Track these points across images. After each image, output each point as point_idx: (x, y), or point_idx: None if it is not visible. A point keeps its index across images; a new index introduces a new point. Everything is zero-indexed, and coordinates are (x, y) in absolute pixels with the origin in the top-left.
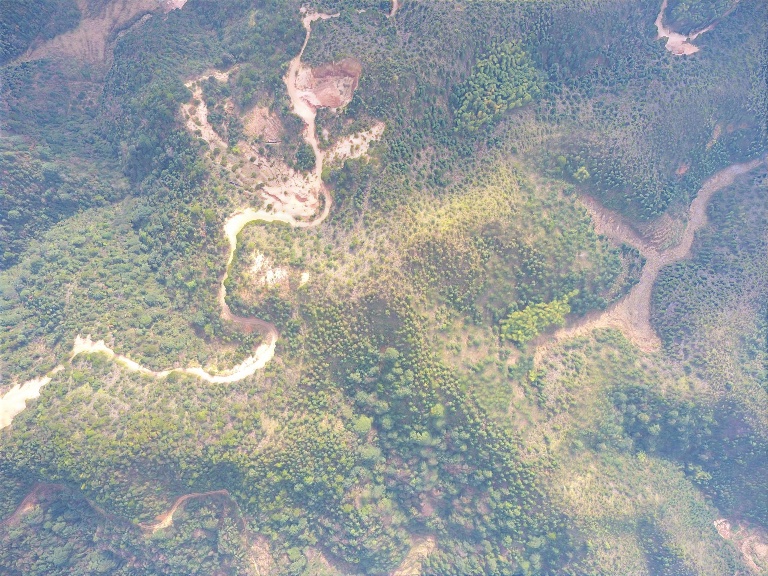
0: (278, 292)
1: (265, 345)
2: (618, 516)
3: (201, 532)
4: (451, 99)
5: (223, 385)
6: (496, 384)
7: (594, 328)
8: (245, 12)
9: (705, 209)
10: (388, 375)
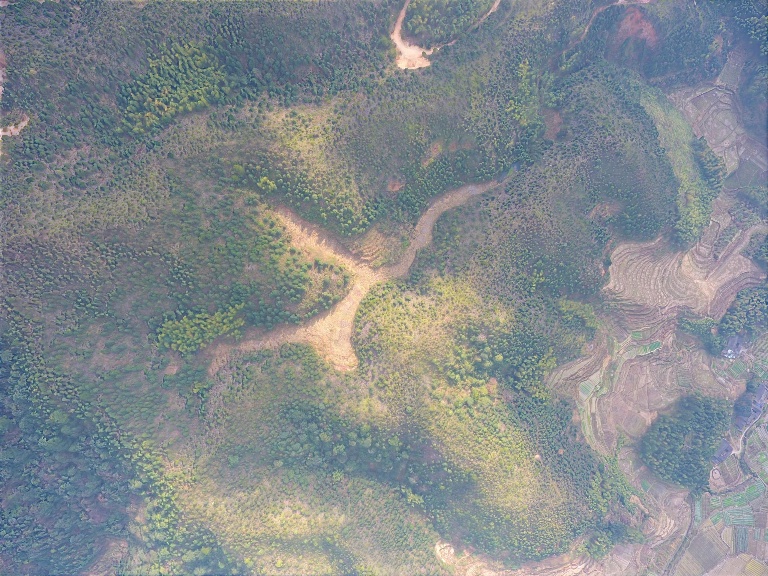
0: None
1: None
2: (287, 535)
3: None
4: (118, 98)
5: None
6: (142, 394)
7: (285, 343)
8: None
9: (432, 229)
10: (9, 377)
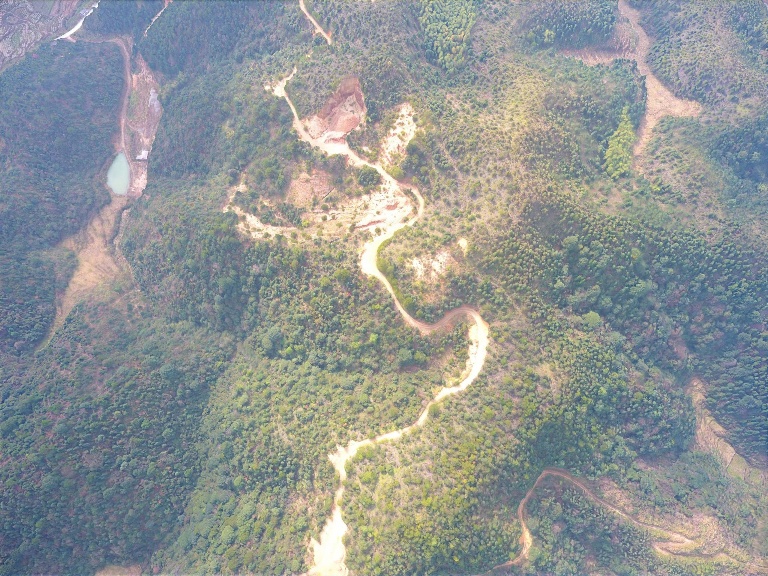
0: (453, 272)
1: (472, 327)
2: None
3: (557, 524)
4: (428, 56)
5: (476, 380)
6: None
7: (651, 129)
8: (213, 135)
9: (629, 6)
10: (580, 261)
